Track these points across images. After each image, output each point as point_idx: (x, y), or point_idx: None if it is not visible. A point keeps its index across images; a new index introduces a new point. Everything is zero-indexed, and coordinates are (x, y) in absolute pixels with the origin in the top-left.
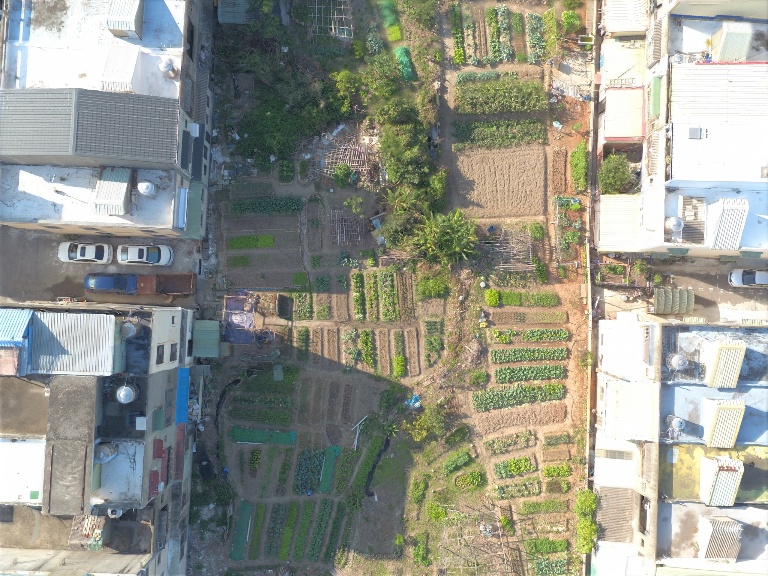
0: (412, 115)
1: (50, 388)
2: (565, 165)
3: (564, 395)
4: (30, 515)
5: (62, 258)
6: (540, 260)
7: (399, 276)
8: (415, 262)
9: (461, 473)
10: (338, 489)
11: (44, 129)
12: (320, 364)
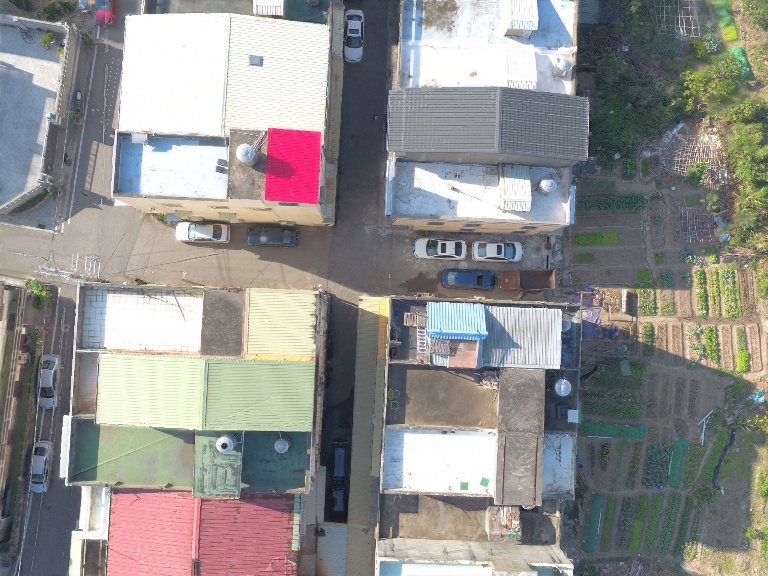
0: (762, 114)
1: (500, 381)
2: None
3: None
4: (435, 506)
5: (420, 254)
6: None
7: (740, 273)
8: (757, 259)
9: None
10: (686, 483)
11: (467, 127)
12: (665, 359)
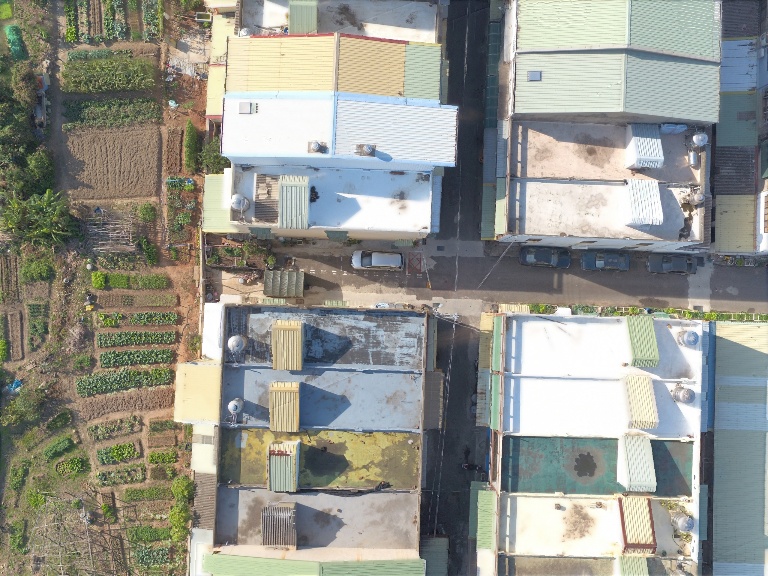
0: (6, 94)
1: None
2: (181, 145)
3: (172, 380)
4: None
5: None
6: (151, 242)
7: (3, 258)
8: (18, 244)
9: (63, 459)
10: None
11: None
12: None
